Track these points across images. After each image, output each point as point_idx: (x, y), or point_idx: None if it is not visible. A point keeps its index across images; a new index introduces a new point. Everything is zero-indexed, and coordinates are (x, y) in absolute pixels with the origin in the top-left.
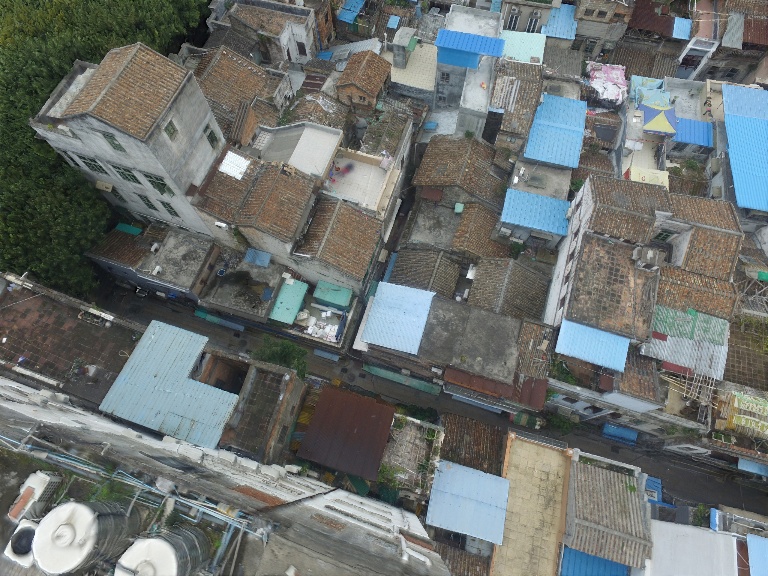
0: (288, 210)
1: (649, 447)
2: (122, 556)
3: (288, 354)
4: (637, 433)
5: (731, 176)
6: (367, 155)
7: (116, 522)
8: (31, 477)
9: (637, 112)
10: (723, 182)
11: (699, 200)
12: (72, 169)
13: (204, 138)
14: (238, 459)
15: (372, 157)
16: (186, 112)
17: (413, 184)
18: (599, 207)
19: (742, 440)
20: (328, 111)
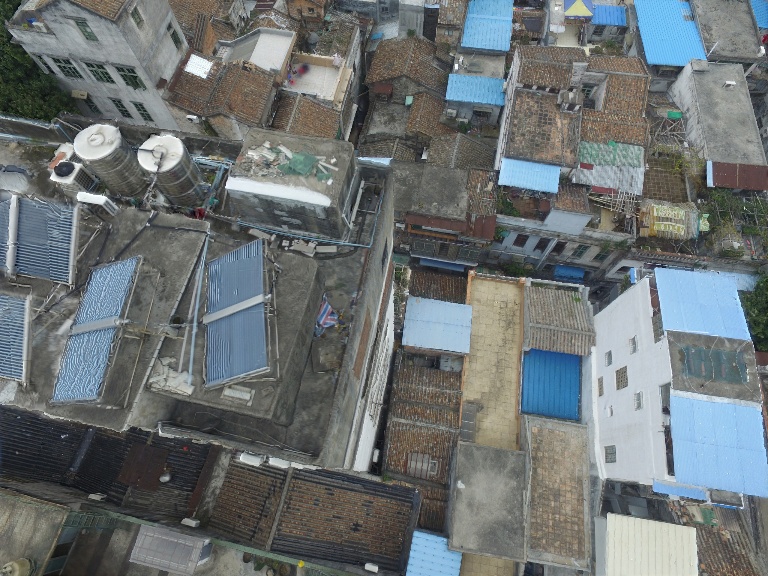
0: (252, 100)
1: (595, 284)
2: (142, 145)
3: None
4: (583, 273)
5: (642, 45)
6: (320, 56)
7: (133, 154)
8: (62, 146)
9: (558, 1)
10: (636, 50)
11: (613, 58)
12: (48, 76)
13: (168, 36)
14: None
15: (325, 57)
16: (149, 4)
17: (365, 83)
18: (524, 62)
19: (666, 250)
20: (281, 25)
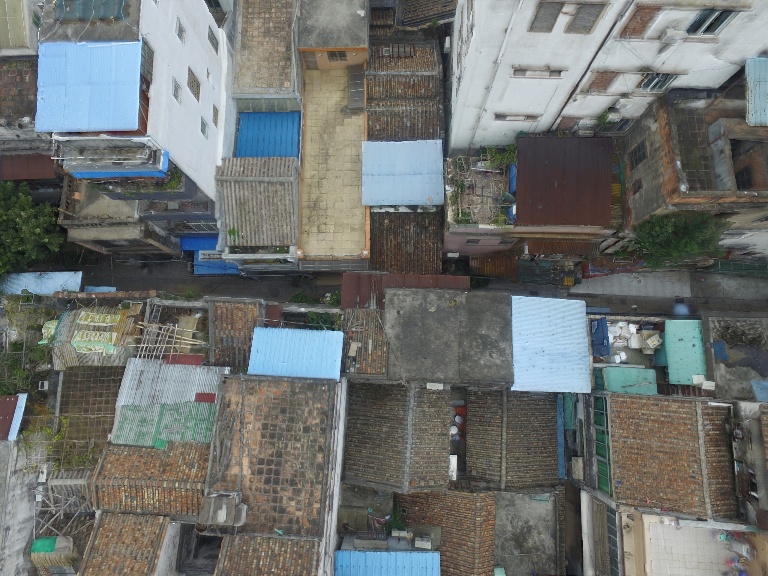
0: None
1: None
2: None
3: (680, 242)
4: None
5: None
6: None
7: None
8: None
9: None
10: None
11: None
12: None
13: None
14: (713, 59)
15: None
16: None
17: None
18: None
19: None
20: None
